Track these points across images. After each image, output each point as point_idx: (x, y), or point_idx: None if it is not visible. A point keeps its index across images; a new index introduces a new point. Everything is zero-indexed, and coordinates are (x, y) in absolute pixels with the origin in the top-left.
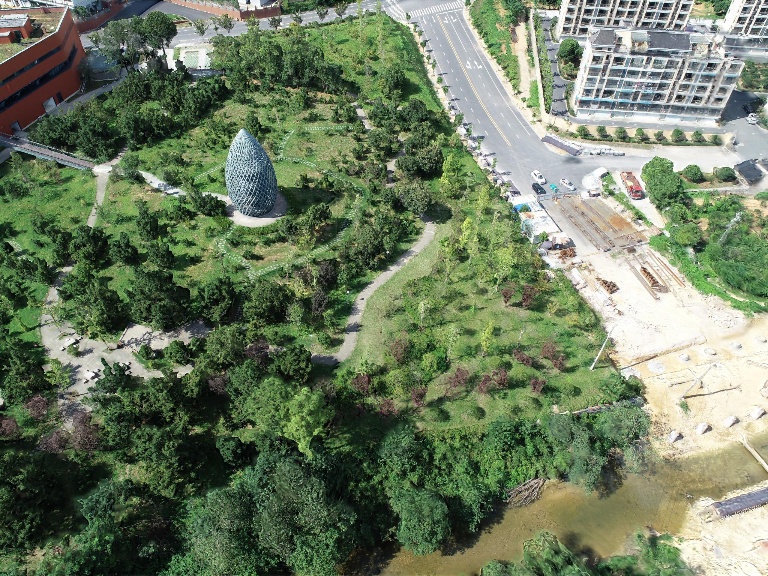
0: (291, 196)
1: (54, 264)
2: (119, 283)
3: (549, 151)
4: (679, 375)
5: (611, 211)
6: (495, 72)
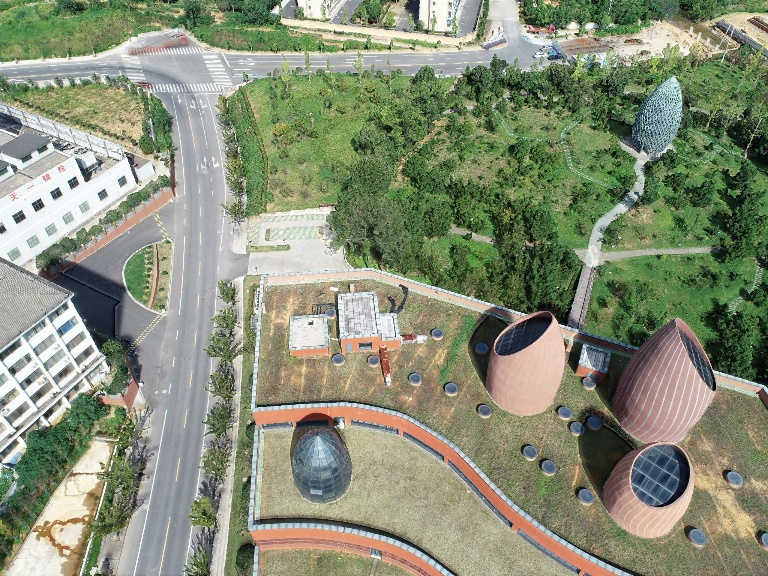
0: (629, 130)
1: (763, 255)
2: (767, 212)
3: (501, 49)
4: (700, 50)
5: (571, 41)
6: (372, 53)
